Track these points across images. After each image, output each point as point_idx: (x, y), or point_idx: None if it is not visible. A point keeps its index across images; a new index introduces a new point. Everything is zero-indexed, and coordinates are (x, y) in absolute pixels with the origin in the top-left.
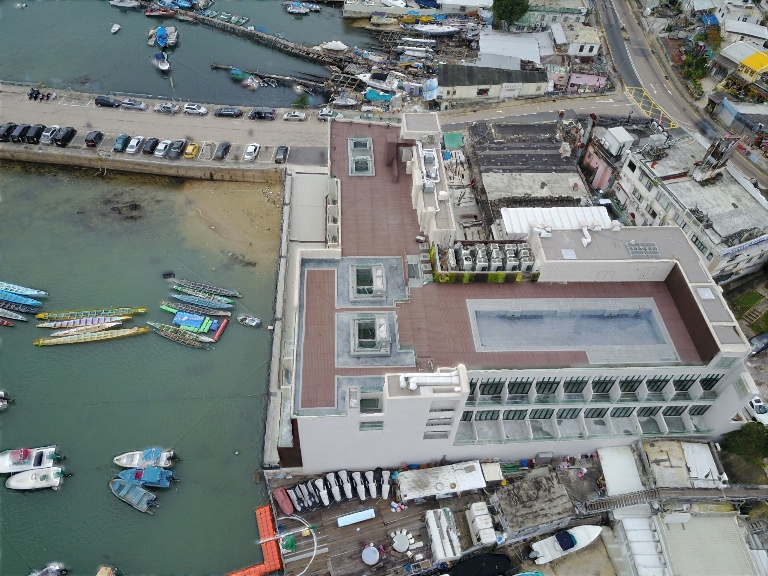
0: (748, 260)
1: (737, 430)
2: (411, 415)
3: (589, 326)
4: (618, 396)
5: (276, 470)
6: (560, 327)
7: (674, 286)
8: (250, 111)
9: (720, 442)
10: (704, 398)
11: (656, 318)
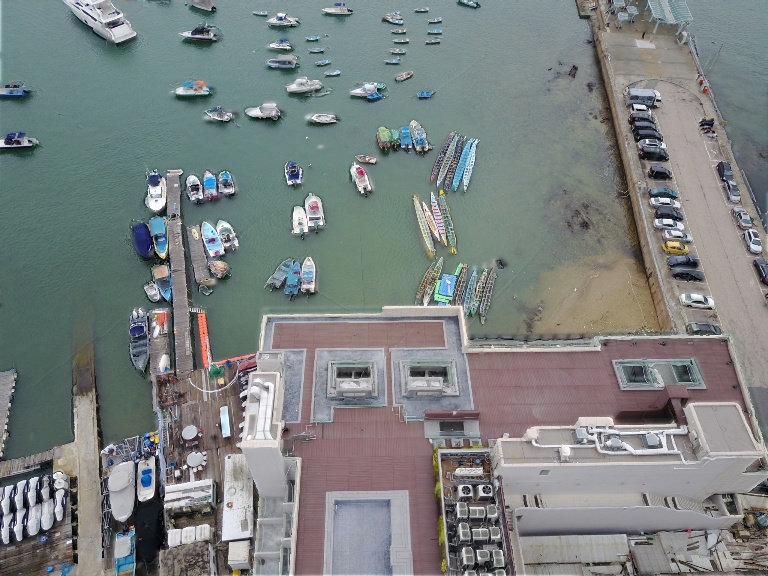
0: None
1: None
2: None
3: None
4: None
5: None
6: None
7: None
8: None
9: None
10: None
11: None
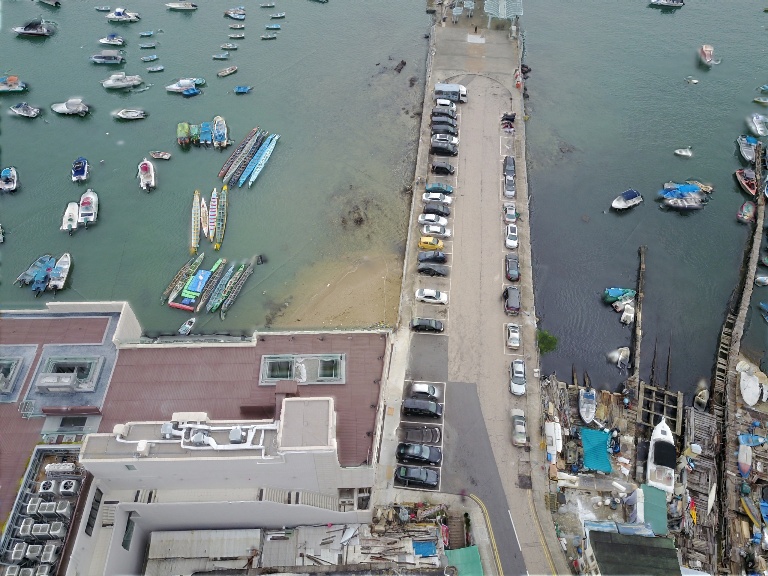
0: None
1: None
2: None
3: None
4: None
5: None
6: None
7: None
8: None
9: None
10: None
11: None
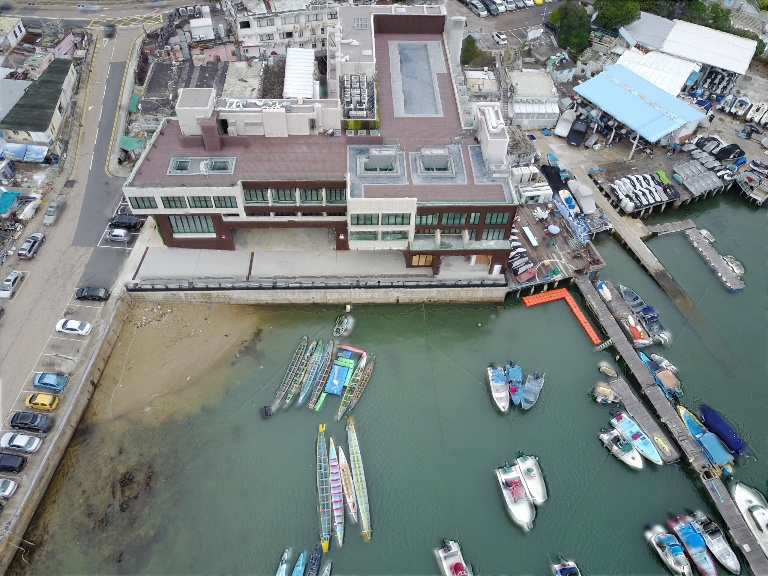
0: None
1: None
2: None
3: (410, 72)
4: (456, 78)
5: None
6: (412, 84)
7: (384, 27)
8: None
9: None
10: None
11: (406, 43)
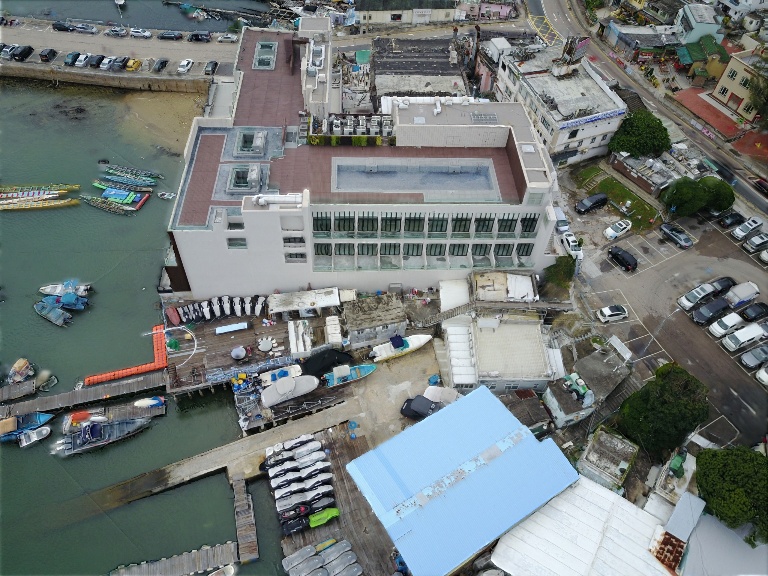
0: (592, 140)
1: (554, 264)
2: (266, 232)
3: (434, 179)
4: (450, 231)
5: (170, 294)
6: (409, 179)
7: (509, 148)
8: (189, 35)
9: (540, 274)
10: (527, 237)
11: (490, 173)
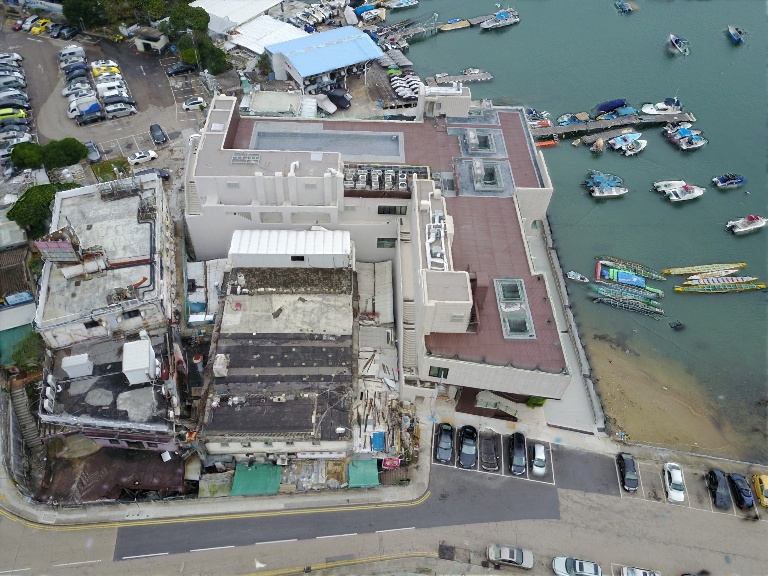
0: None
1: None
2: None
3: None
4: None
5: None
6: None
7: None
8: None
9: None
10: None
11: None
